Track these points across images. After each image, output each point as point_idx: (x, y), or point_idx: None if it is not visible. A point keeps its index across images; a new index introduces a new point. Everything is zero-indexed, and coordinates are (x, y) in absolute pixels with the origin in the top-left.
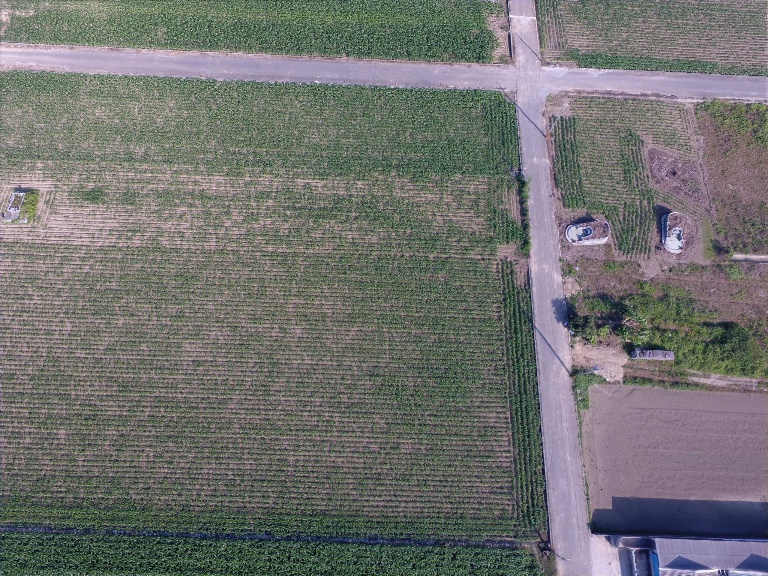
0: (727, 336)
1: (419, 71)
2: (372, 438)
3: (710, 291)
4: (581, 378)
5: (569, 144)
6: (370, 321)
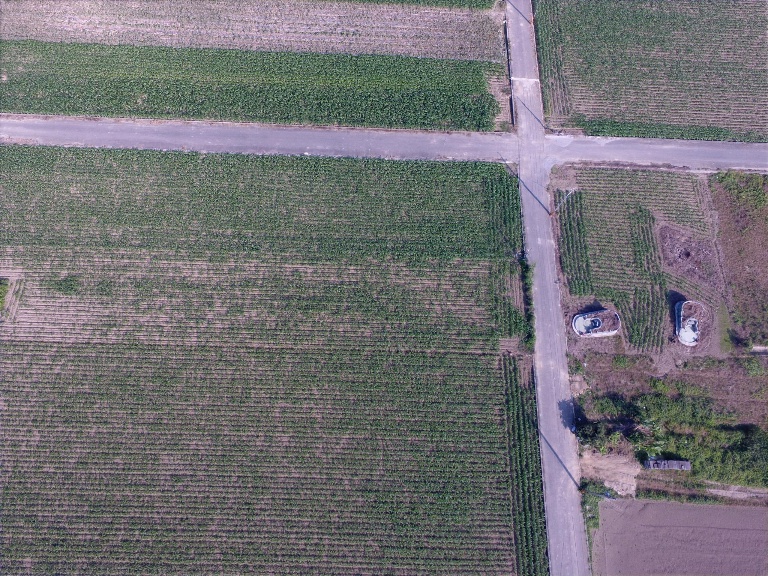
0: (747, 442)
1: (415, 141)
2: (364, 564)
3: (728, 389)
4: (590, 493)
5: (575, 222)
6: (363, 427)
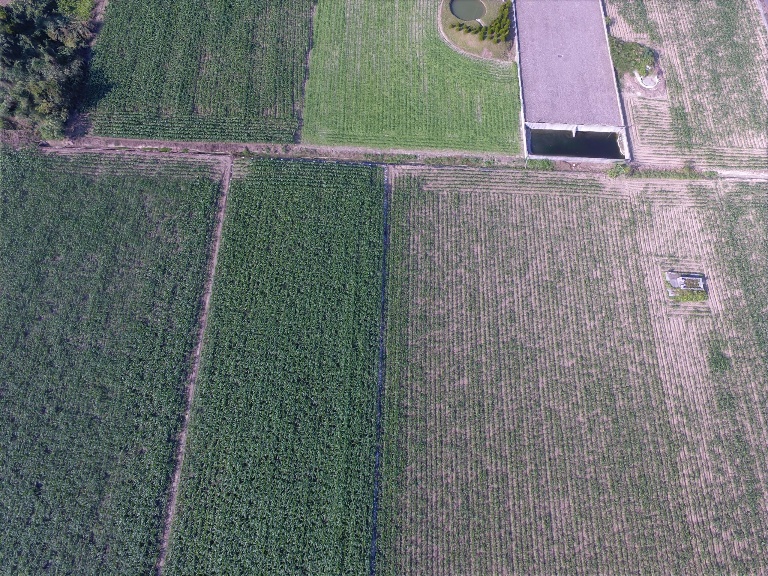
0: None
1: None
2: None
3: None
4: None
5: None
6: None
